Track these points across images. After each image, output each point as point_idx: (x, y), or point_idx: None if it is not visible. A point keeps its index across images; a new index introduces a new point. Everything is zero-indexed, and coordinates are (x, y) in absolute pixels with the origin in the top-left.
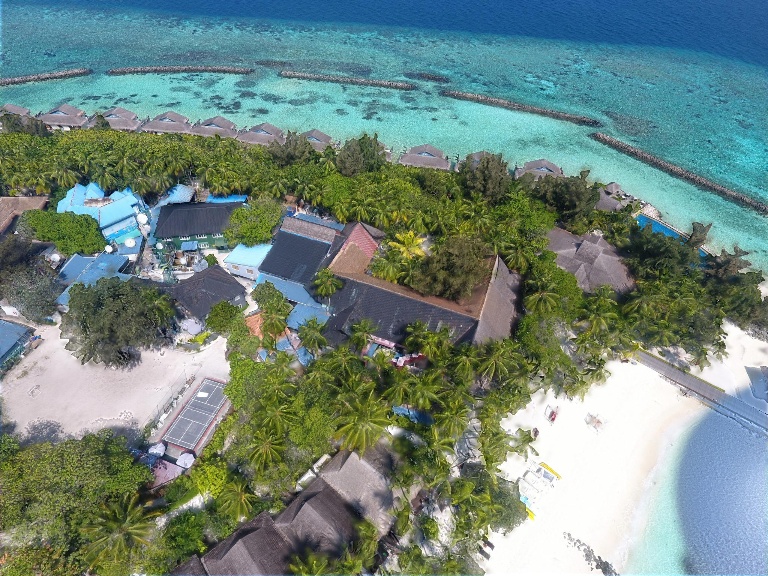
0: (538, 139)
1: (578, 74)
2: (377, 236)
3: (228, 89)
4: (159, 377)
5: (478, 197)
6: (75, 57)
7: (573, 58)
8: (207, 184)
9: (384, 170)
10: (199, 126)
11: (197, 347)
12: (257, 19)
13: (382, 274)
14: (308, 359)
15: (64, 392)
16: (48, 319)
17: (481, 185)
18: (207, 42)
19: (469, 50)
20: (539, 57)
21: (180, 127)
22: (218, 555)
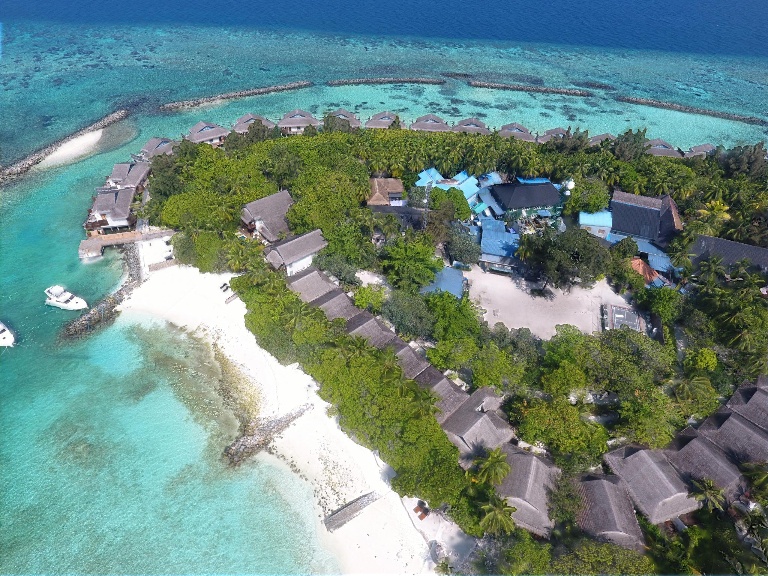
0: (724, 136)
1: (719, 82)
2: (676, 207)
3: (437, 97)
4: (577, 305)
5: (743, 177)
6: (287, 71)
7: (705, 68)
8: (507, 170)
9: (645, 158)
10: (459, 126)
11: (589, 285)
12: (409, 37)
13: (703, 233)
14: (684, 292)
15: (518, 314)
16: (466, 266)
17: (746, 167)
18: (385, 58)
19: (611, 62)
20: (675, 68)
21: (443, 127)
22: (740, 402)
